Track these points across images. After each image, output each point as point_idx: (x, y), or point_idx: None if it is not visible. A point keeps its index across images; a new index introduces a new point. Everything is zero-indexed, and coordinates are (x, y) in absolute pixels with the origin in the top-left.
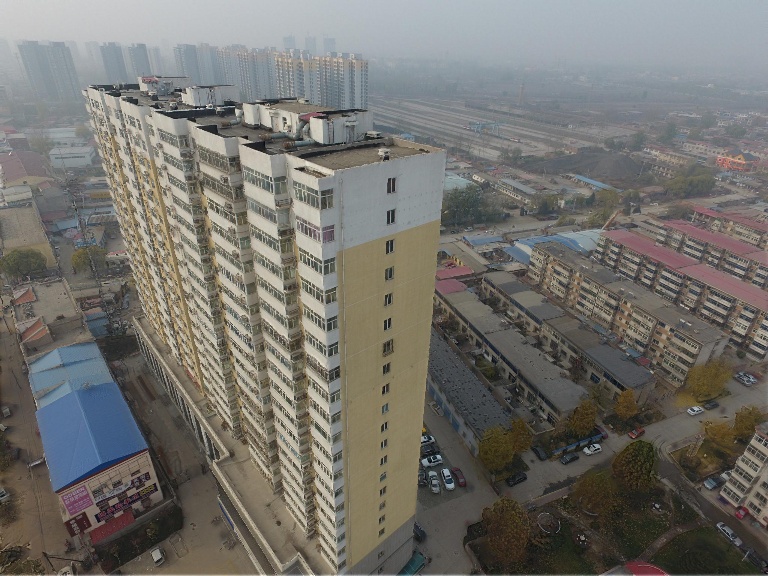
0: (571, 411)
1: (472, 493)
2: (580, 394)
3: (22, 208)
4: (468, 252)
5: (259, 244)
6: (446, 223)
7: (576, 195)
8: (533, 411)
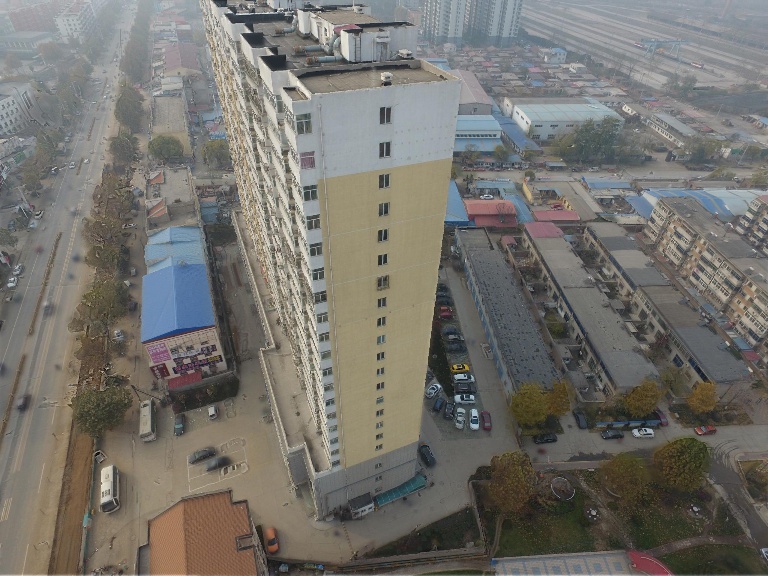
0: (630, 388)
1: (494, 439)
2: (648, 373)
3: (173, 97)
4: (582, 195)
5: (275, 160)
6: (570, 159)
7: None
8: (590, 378)
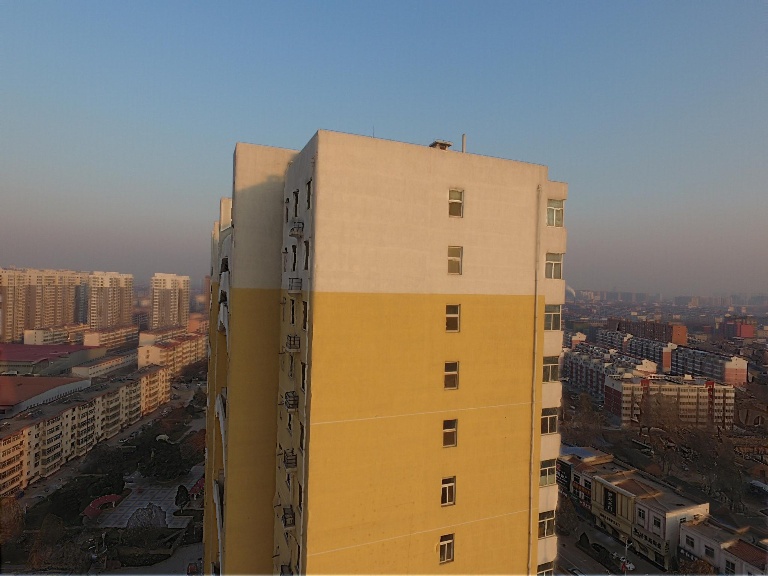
0: None
1: None
2: None
3: None
4: None
5: None
6: None
7: None
8: None
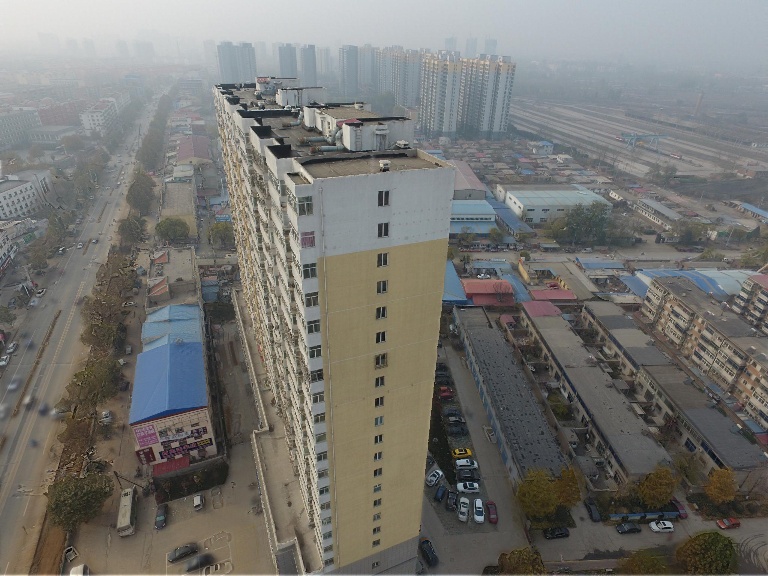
0: (642, 475)
1: (501, 533)
2: (660, 459)
3: (184, 183)
4: (577, 275)
5: (277, 240)
6: (563, 241)
7: (733, 227)
8: (599, 464)
